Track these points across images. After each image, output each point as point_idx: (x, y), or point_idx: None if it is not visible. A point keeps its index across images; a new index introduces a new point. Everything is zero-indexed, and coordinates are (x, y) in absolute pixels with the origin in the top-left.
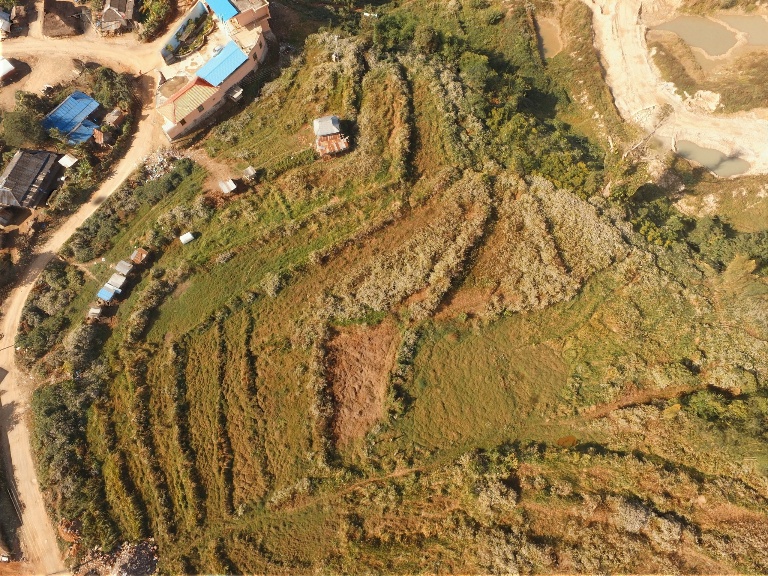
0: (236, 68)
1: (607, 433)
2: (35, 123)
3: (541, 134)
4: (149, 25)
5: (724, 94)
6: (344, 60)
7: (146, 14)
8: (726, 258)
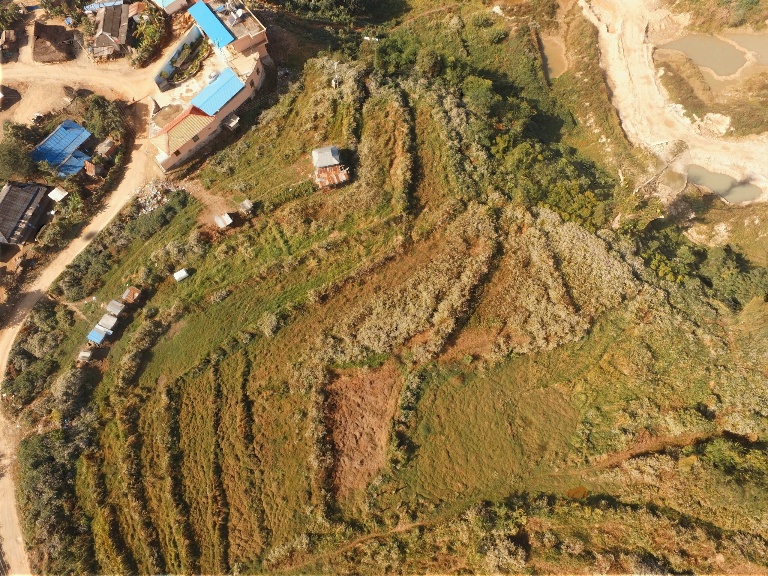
0: (232, 96)
1: (619, 484)
2: (24, 156)
3: (547, 161)
4: (143, 50)
5: (734, 117)
6: (344, 86)
7: (140, 38)
8: (741, 295)
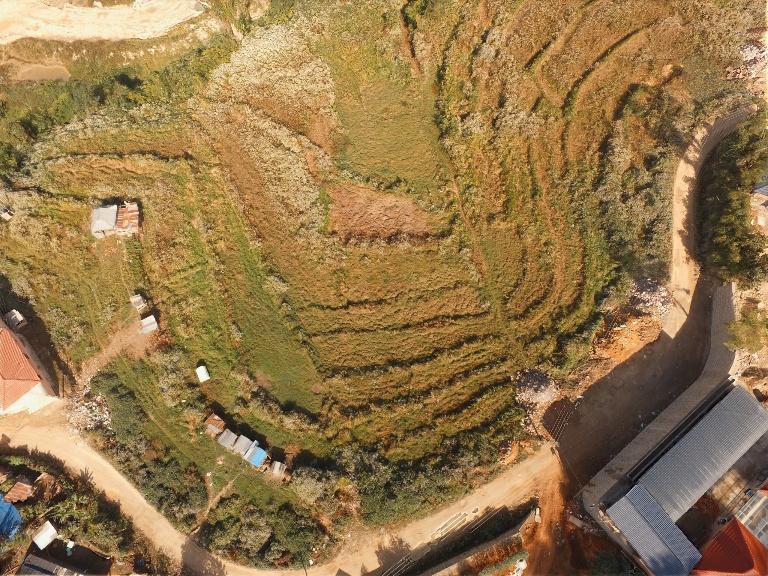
0: None
1: (430, 65)
2: None
3: None
4: None
5: None
6: (15, 205)
7: None
8: None
